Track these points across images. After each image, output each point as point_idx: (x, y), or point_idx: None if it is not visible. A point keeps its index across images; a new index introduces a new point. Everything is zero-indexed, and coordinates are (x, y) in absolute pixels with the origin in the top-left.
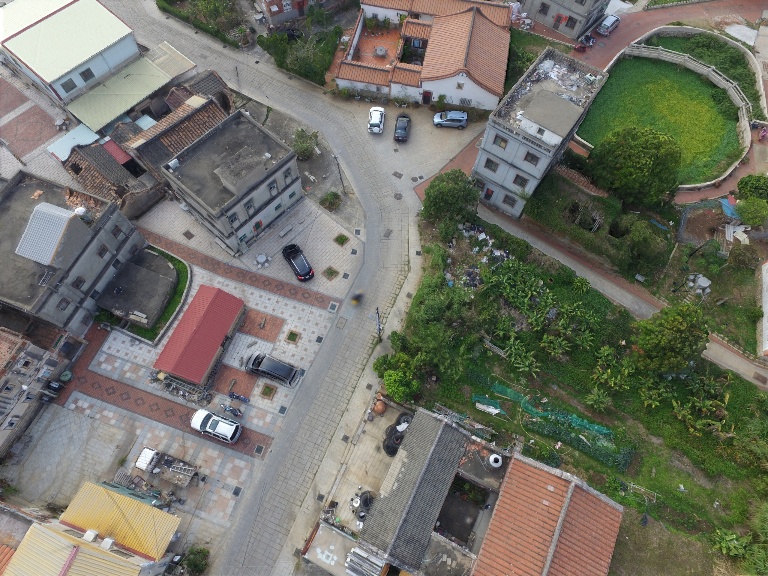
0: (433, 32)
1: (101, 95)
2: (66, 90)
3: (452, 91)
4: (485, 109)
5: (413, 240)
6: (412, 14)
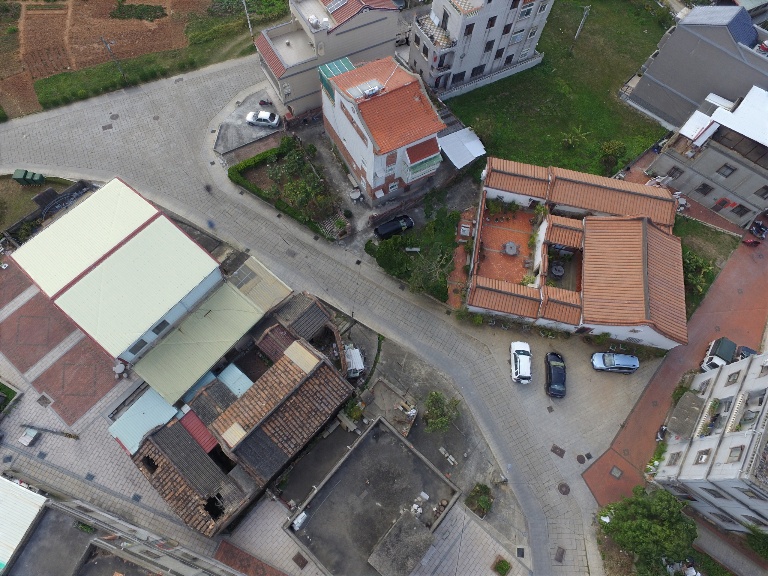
0: (588, 243)
1: (176, 346)
2: (134, 352)
3: (621, 332)
4: (656, 347)
5: (595, 567)
6: (551, 204)
